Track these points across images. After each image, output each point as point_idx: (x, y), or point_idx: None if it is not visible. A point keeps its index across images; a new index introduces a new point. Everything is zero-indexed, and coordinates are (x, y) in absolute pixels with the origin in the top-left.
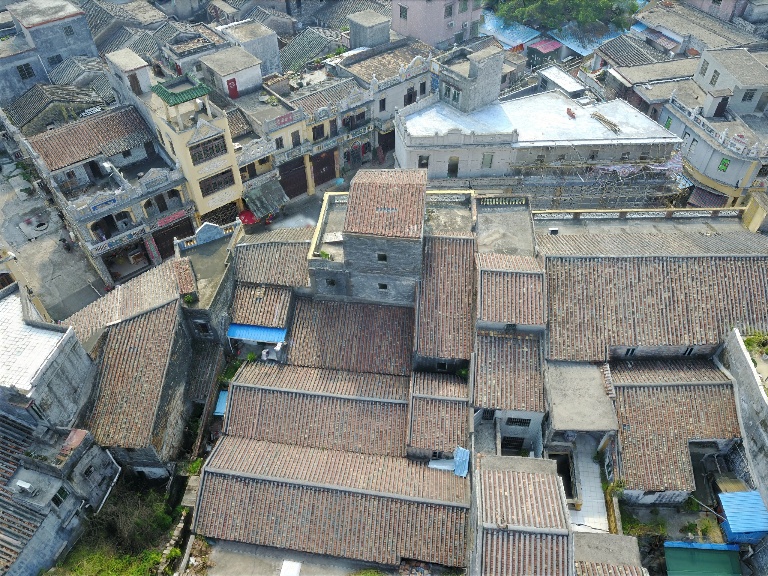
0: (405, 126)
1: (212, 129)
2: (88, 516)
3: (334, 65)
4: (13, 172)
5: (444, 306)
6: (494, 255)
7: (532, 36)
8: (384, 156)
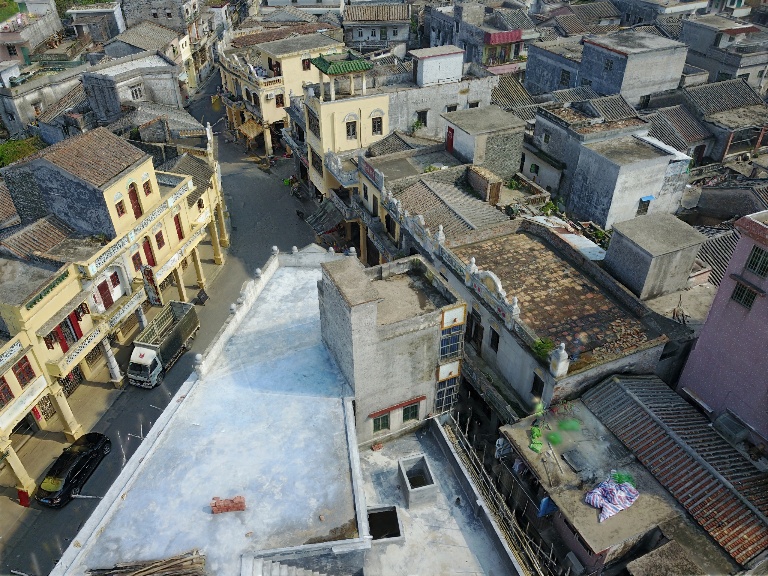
0: None
1: None
2: None
3: None
4: None
5: None
6: None
7: None
8: None
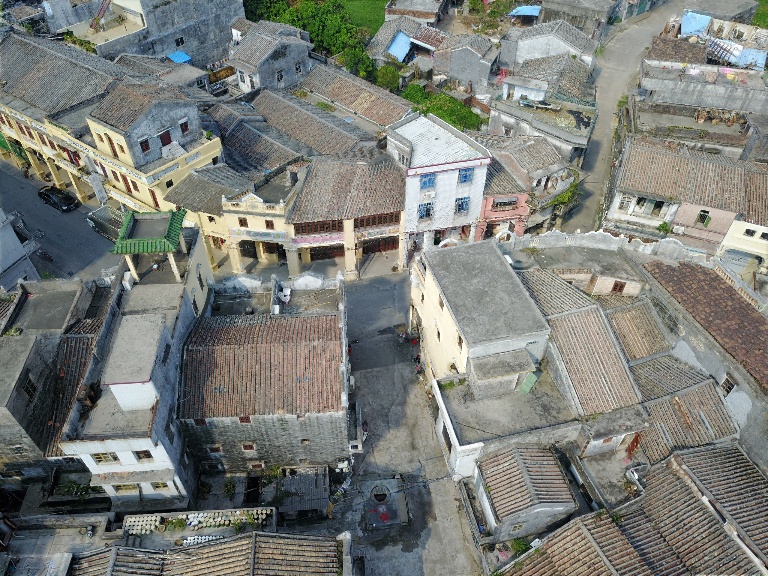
0: None
1: None
2: None
3: None
4: None
5: None
6: None
7: None
8: None
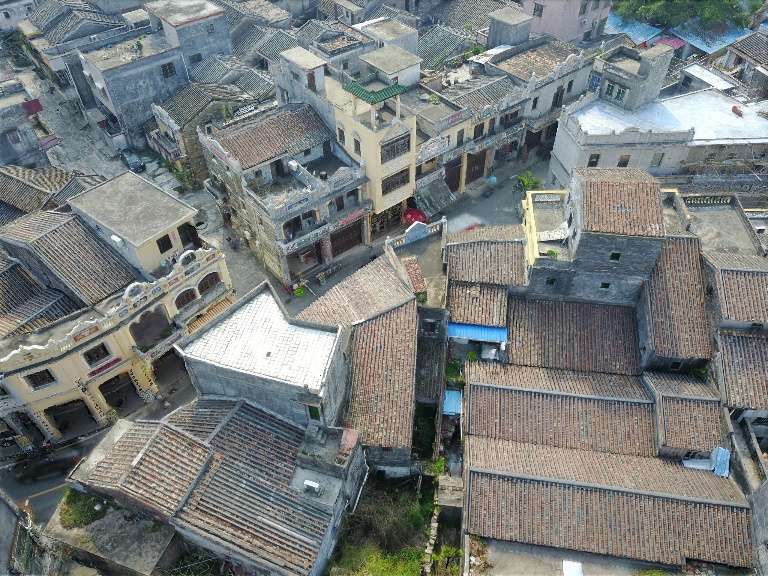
0: (580, 124)
1: (402, 128)
2: (346, 515)
3: (483, 63)
4: (157, 171)
5: (676, 305)
6: (721, 254)
7: (654, 34)
8: (528, 154)
